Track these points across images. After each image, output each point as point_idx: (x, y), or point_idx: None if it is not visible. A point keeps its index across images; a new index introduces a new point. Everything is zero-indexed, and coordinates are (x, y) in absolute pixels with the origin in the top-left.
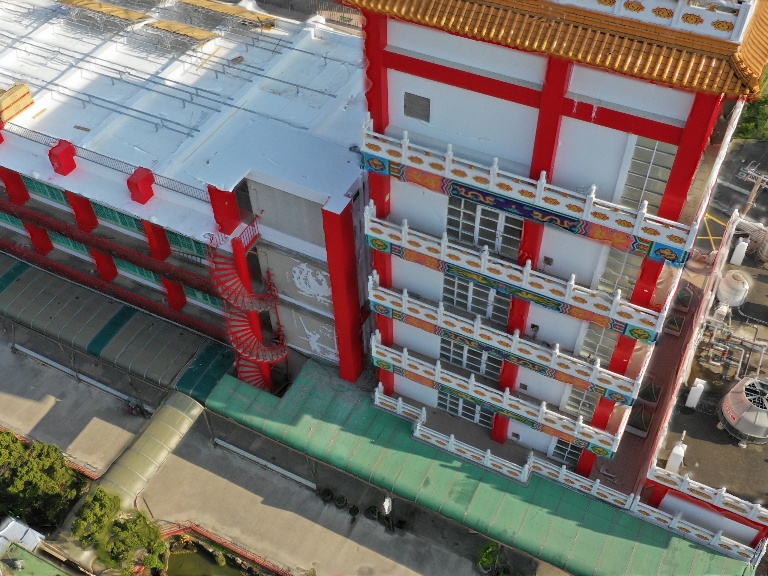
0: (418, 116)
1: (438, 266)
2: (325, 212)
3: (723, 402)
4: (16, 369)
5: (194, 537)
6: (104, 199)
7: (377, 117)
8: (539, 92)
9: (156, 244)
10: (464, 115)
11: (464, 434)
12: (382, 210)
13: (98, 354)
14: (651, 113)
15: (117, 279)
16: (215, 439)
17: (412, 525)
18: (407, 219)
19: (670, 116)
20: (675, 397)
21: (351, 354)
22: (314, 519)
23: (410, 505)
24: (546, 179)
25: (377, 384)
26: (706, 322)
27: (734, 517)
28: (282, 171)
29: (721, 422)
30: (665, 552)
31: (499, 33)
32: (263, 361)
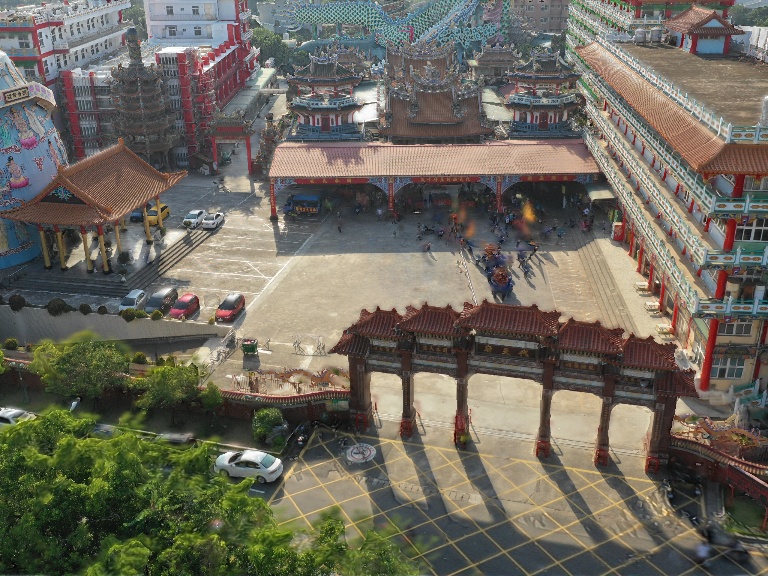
0: None
1: None
2: None
3: None
4: None
5: None
6: None
7: None
8: None
9: None
10: None
11: None
12: None
13: None
14: None
15: None
16: None
17: None
18: None
19: None
20: None
21: None
22: None
23: None
24: None
25: None
26: None
27: None
28: None
29: None
30: None
31: None
32: None
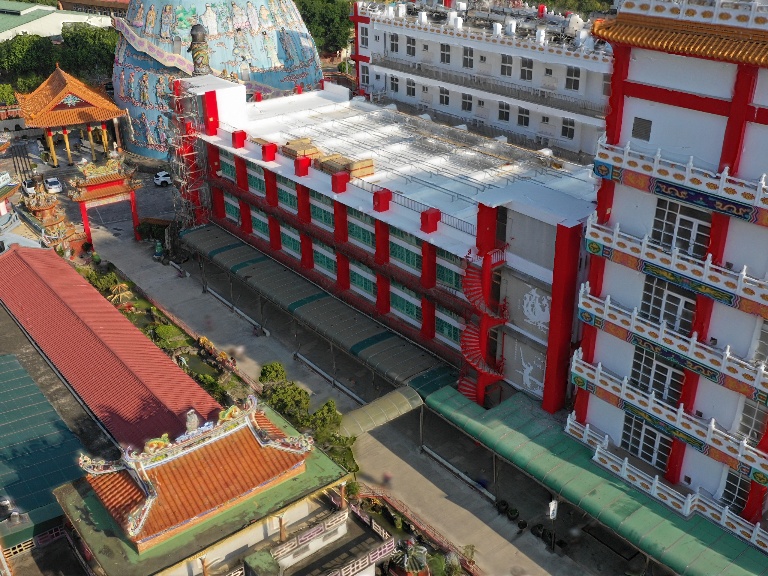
0: (642, 137)
1: (637, 265)
2: (559, 227)
3: None
4: (292, 368)
5: (383, 504)
6: (401, 227)
7: (611, 136)
8: (730, 102)
9: (427, 273)
10: (675, 132)
11: (638, 465)
12: (602, 220)
13: (357, 353)
14: None
15: (388, 314)
16: (423, 445)
17: (572, 551)
18: (620, 223)
19: None
20: None
21: (555, 379)
22: (486, 521)
23: (575, 537)
24: (729, 173)
25: None
26: None
27: None
28: (535, 204)
29: None
30: None
31: (702, 48)
32: (481, 370)
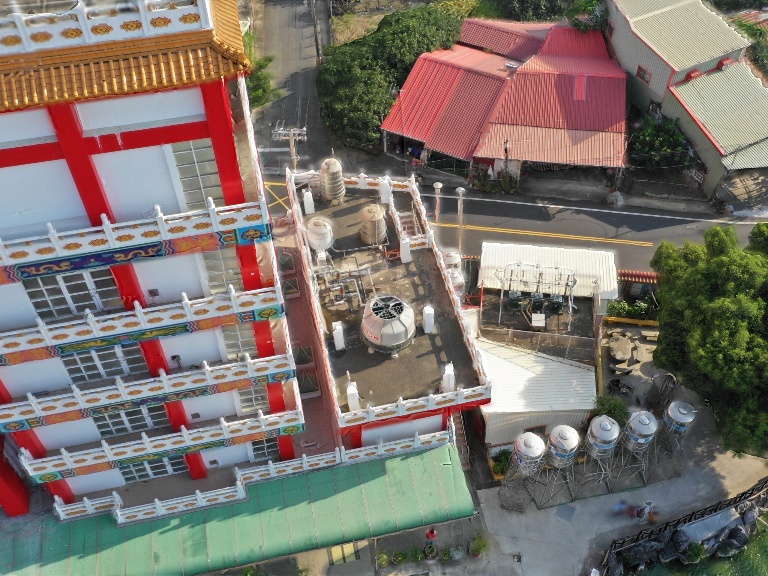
0: None
1: (49, 353)
2: None
3: (363, 330)
4: None
5: None
6: None
7: None
8: (56, 143)
9: None
10: None
11: (166, 491)
12: None
13: None
14: (171, 119)
15: None
16: None
17: None
18: None
19: (189, 115)
20: (325, 348)
21: (7, 488)
22: None
23: None
24: (109, 220)
25: (53, 500)
26: (314, 273)
27: (420, 416)
28: None
29: (370, 347)
30: (387, 478)
31: None
32: None
